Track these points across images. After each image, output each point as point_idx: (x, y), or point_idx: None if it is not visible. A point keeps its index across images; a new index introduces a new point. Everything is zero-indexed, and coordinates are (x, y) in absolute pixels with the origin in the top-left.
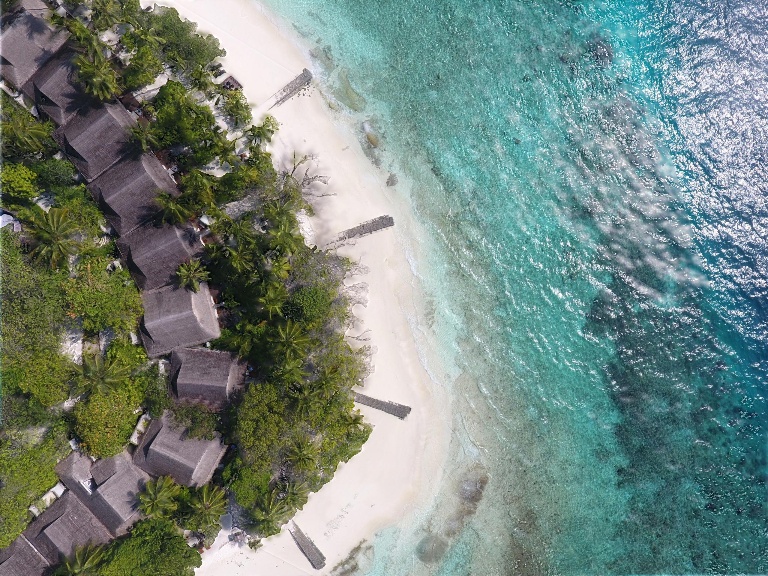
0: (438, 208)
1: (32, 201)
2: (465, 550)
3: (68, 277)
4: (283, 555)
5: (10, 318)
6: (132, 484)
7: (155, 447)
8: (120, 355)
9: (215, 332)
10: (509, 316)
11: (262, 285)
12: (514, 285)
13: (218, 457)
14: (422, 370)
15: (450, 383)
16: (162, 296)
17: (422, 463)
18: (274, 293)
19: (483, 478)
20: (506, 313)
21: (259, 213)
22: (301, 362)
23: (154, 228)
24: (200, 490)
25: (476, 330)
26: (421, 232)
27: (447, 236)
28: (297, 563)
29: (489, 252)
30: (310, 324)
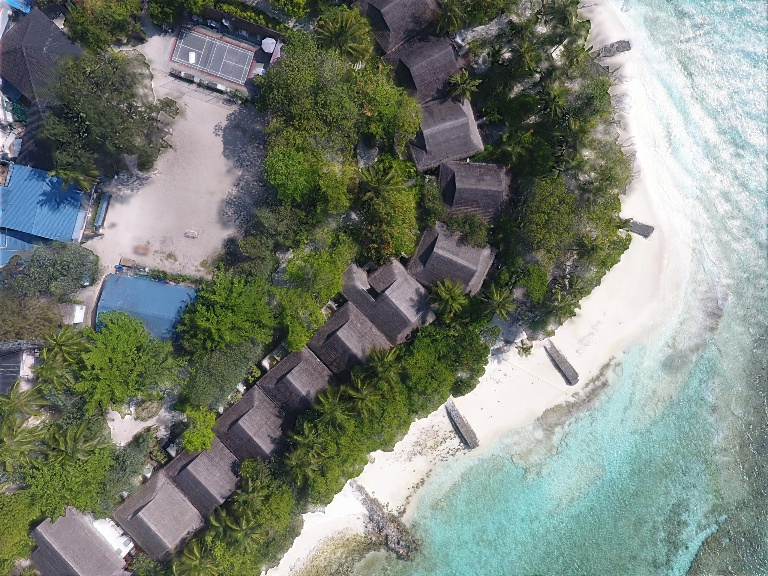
0: (670, 33)
1: (289, 27)
2: (708, 366)
3: (352, 84)
4: (538, 372)
5: (312, 115)
6: (411, 291)
7: (438, 250)
8: (395, 166)
9: (480, 145)
10: (741, 138)
11: (544, 83)
12: (745, 108)
13: (487, 267)
14: (662, 191)
15: (688, 204)
16: (431, 109)
17: (665, 282)
18: (559, 89)
19: (723, 295)
20: (738, 136)
21: (506, 36)
22: (582, 159)
23: (421, 42)
24: (474, 298)
25: (711, 152)
26: (655, 57)
27: (680, 61)
28: (551, 380)
29: (720, 76)
30: (592, 120)
